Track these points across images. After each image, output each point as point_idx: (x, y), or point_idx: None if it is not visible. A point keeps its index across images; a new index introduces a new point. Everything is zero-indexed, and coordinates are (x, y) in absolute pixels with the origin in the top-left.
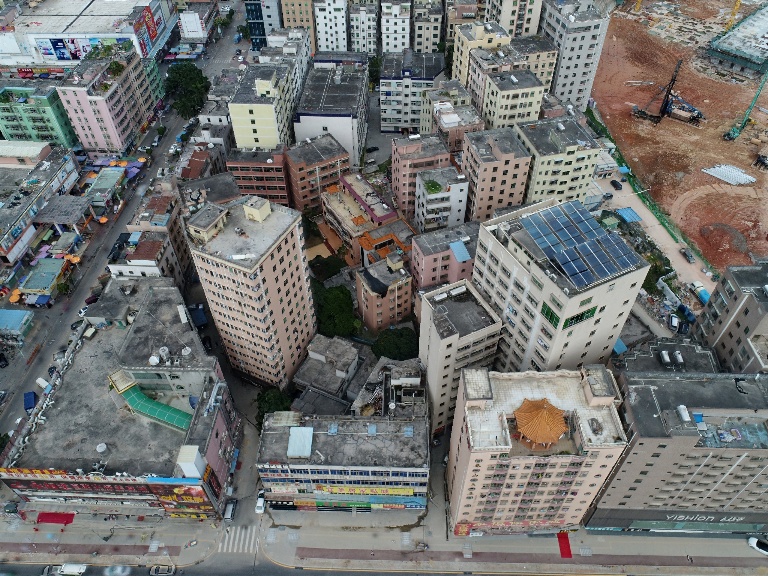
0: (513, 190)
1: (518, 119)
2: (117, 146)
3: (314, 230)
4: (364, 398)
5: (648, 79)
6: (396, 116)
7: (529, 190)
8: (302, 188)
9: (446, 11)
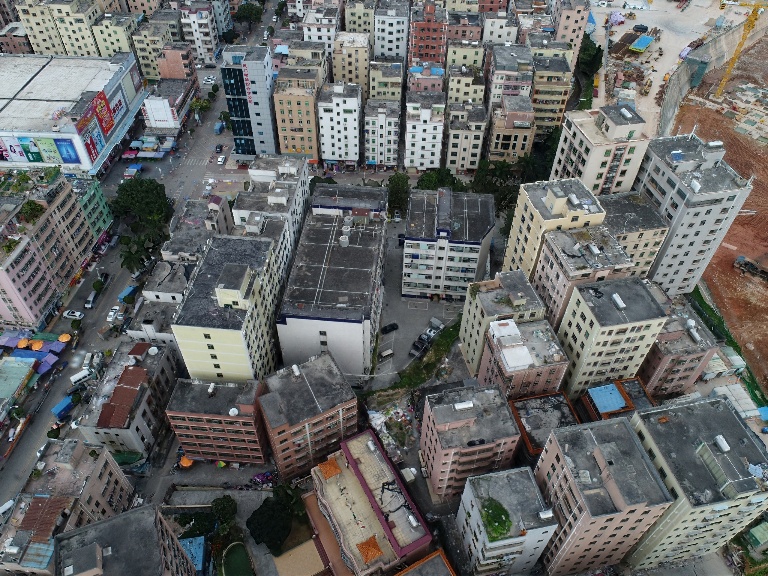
0: (630, 531)
1: (619, 354)
2: (29, 320)
3: (299, 515)
4: None
5: (747, 206)
6: (424, 281)
7: (656, 528)
8: (283, 450)
9: (489, 110)
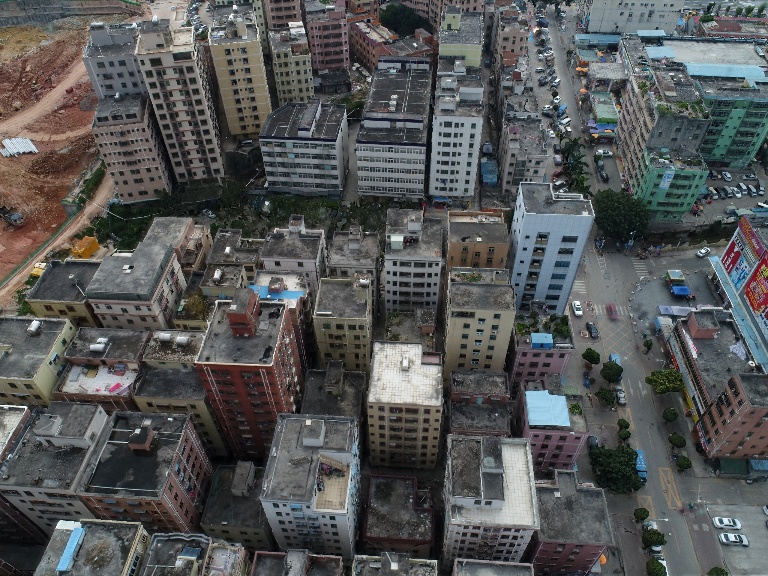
0: None
1: None
2: None
3: None
4: None
5: None
6: None
7: None
8: None
9: None
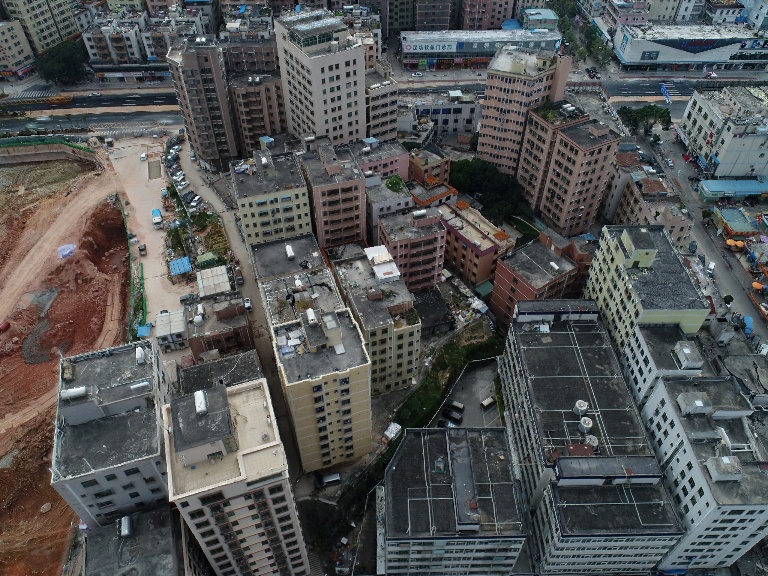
0: None
1: None
2: None
3: None
4: (428, 126)
5: None
6: None
7: None
8: None
9: None
